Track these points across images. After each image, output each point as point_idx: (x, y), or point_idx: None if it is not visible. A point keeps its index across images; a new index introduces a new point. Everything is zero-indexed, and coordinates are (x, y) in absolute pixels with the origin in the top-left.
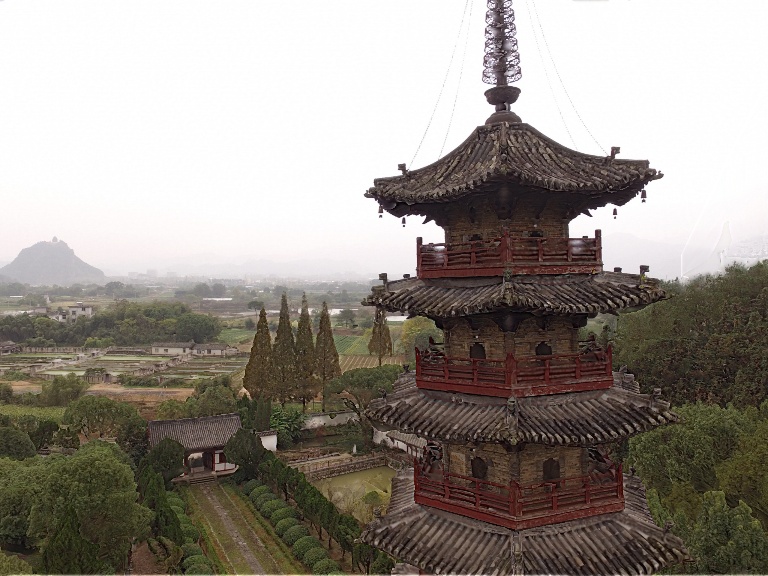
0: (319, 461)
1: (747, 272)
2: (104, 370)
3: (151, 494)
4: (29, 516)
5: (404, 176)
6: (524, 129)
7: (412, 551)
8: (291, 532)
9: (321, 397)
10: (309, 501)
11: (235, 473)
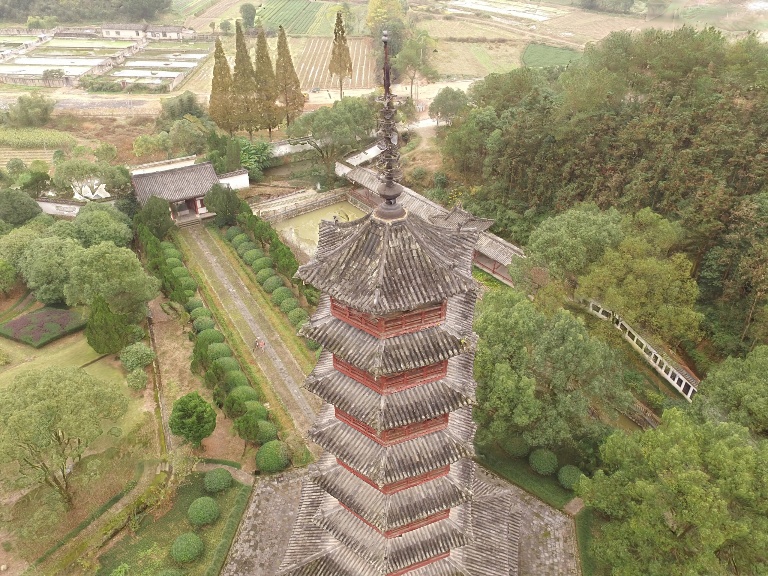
0: (288, 199)
1: (689, 43)
2: (61, 71)
3: (152, 256)
4: (64, 293)
5: (319, 262)
6: (403, 224)
7: (333, 447)
8: (269, 283)
9: (286, 122)
10: (281, 262)
11: (217, 218)
